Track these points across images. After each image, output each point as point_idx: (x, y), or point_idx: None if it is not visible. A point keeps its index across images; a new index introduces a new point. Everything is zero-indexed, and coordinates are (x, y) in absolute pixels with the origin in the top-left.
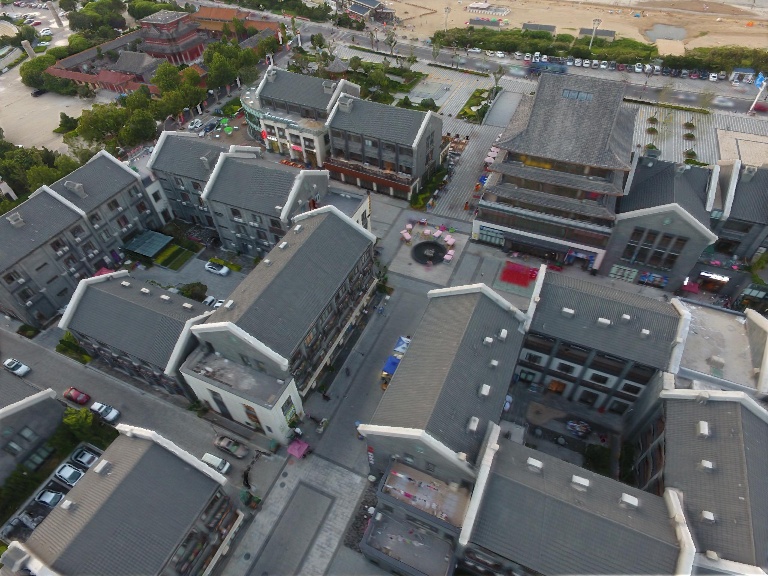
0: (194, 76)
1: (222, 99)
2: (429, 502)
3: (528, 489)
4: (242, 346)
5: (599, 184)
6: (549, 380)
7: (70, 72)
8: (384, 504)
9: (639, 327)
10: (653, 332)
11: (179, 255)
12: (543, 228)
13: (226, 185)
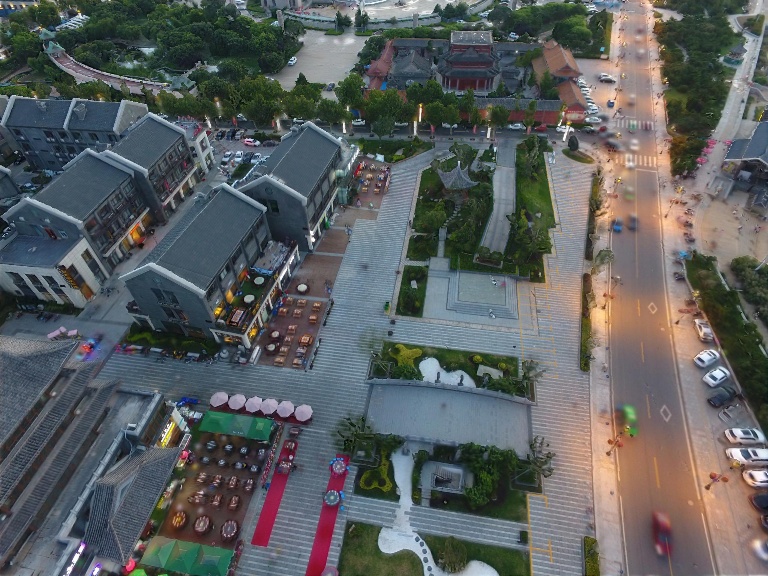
0: (375, 99)
1: None
2: None
3: None
4: None
5: None
6: None
7: None
8: None
9: None
10: None
11: None
12: None
13: None
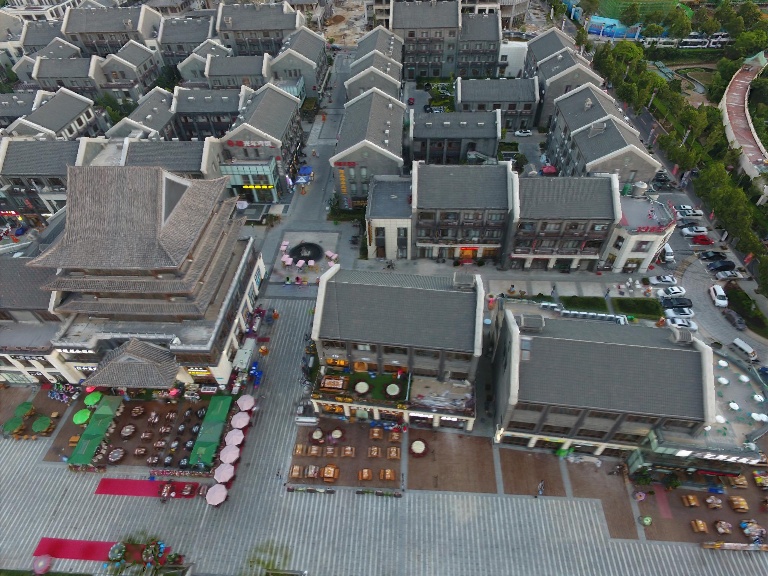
0: None
1: None
2: None
3: None
4: None
5: None
6: None
7: None
8: None
9: None
10: None
11: None
12: None
13: None
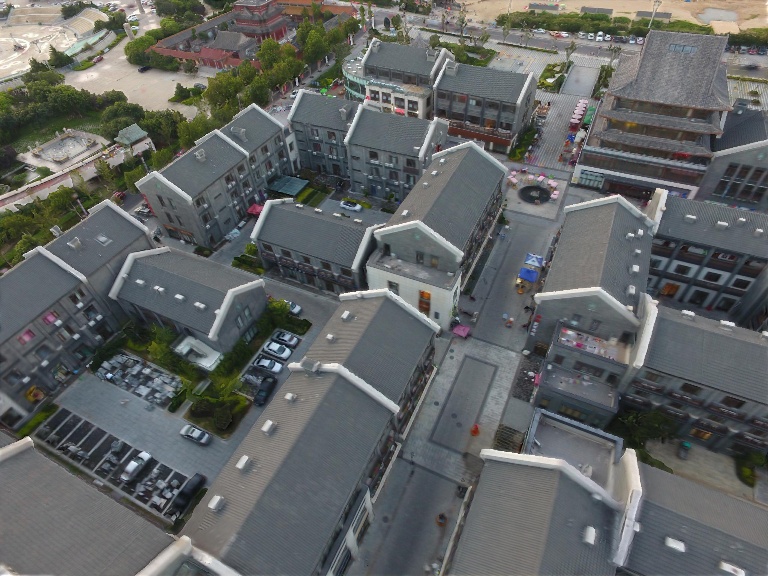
0: (291, 52)
1: (313, 74)
2: (598, 348)
3: (689, 326)
4: (424, 242)
5: (700, 125)
6: (664, 283)
7: (171, 50)
8: (557, 355)
9: (753, 228)
10: (765, 232)
11: (315, 196)
12: (642, 169)
13: (365, 131)
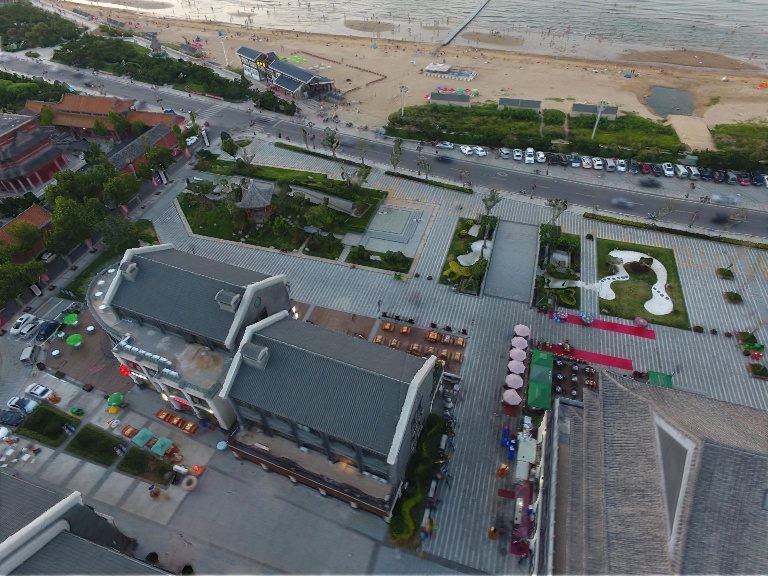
0: (26, 234)
1: (80, 257)
2: None
3: None
4: None
5: None
6: None
7: None
8: None
9: None
10: None
11: None
12: None
13: None
